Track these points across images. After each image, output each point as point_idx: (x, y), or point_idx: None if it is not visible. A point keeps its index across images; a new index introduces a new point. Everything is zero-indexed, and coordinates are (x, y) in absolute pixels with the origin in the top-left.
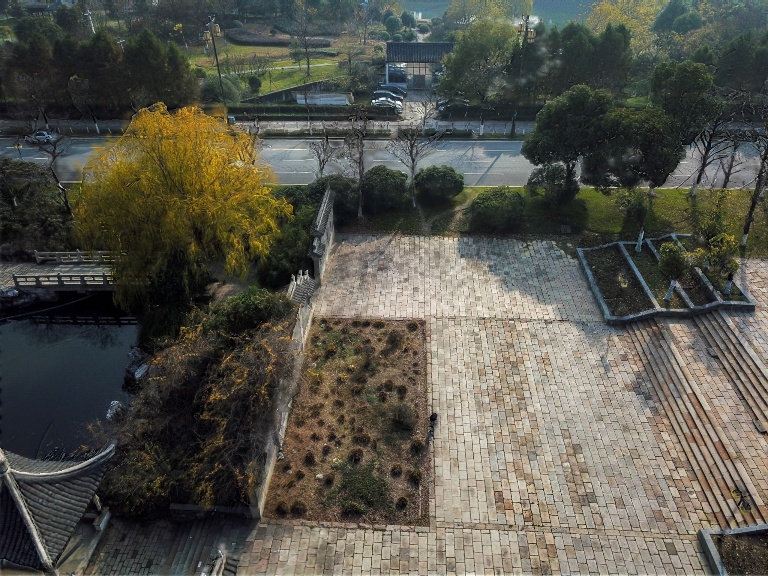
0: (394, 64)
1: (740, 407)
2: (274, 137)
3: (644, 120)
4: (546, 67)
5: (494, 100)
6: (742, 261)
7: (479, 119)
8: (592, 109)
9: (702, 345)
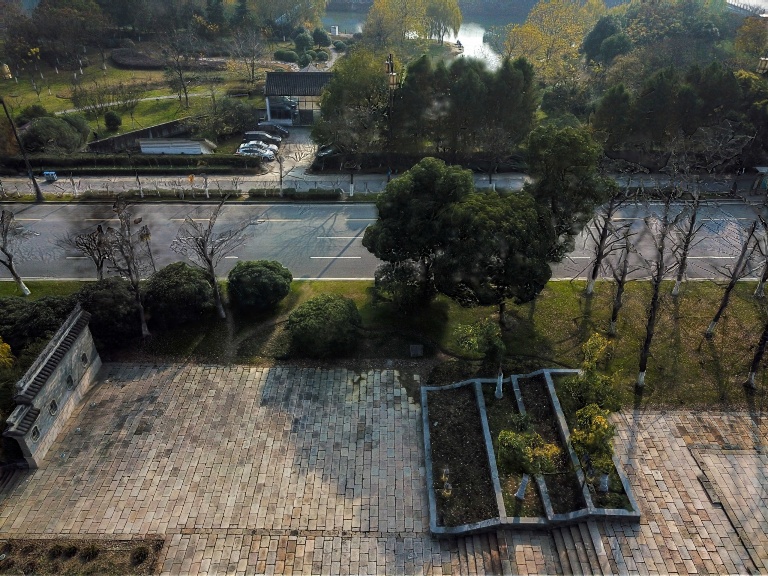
0: (275, 98)
1: None
2: (94, 201)
3: (504, 216)
4: (434, 109)
5: (378, 147)
6: (635, 416)
7: (357, 172)
8: (444, 193)
9: None
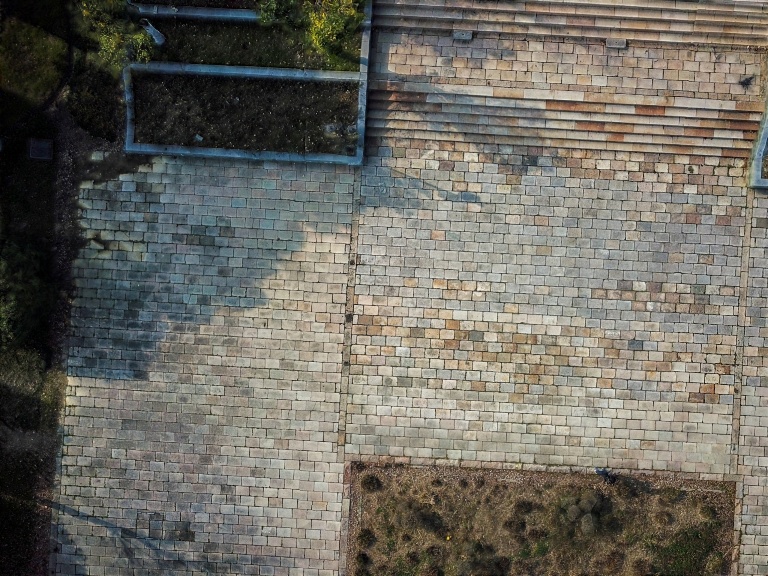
0: None
1: (579, 50)
2: None
3: None
4: None
5: None
6: None
7: None
8: None
9: (444, 42)
